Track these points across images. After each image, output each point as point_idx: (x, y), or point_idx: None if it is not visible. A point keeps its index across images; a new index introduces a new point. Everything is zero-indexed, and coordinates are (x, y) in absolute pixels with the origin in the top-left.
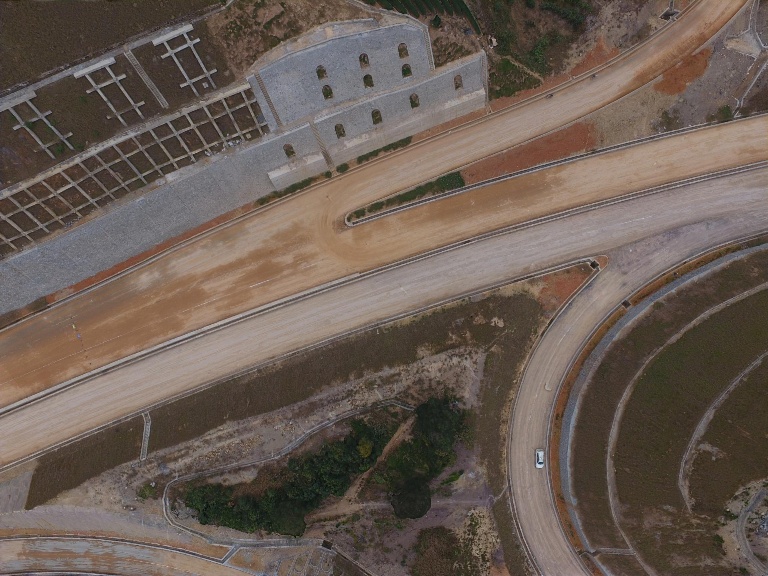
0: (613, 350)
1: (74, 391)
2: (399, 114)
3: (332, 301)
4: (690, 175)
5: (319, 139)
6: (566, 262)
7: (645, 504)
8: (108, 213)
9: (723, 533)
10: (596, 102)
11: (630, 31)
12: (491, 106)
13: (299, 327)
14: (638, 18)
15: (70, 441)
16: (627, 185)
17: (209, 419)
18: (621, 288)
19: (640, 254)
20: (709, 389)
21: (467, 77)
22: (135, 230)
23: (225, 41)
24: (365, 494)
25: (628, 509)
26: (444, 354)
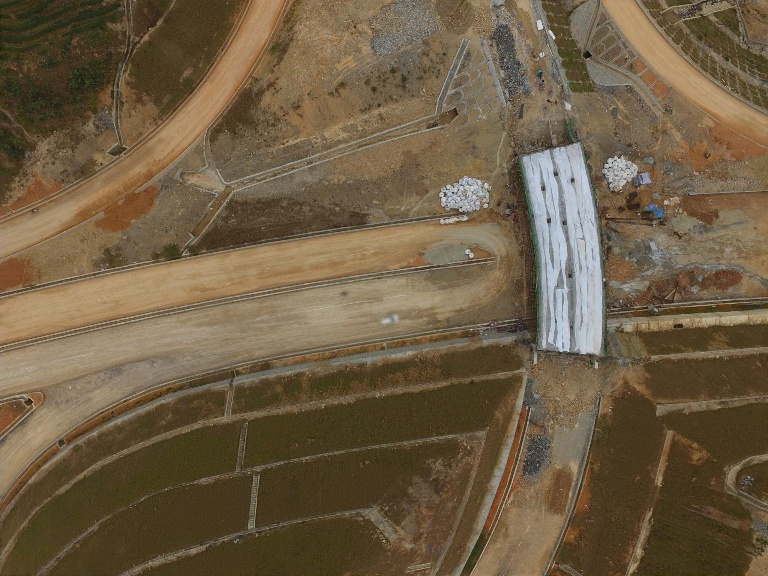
0: (26, 493)
1: None
2: None
3: None
4: (136, 312)
5: None
6: None
7: None
8: None
9: None
10: (35, 237)
11: (69, 167)
12: None
13: None
14: (76, 155)
15: None
16: (69, 321)
17: None
18: (58, 425)
19: (80, 391)
20: (45, 554)
21: None
22: None
23: None
24: None
25: None
26: None
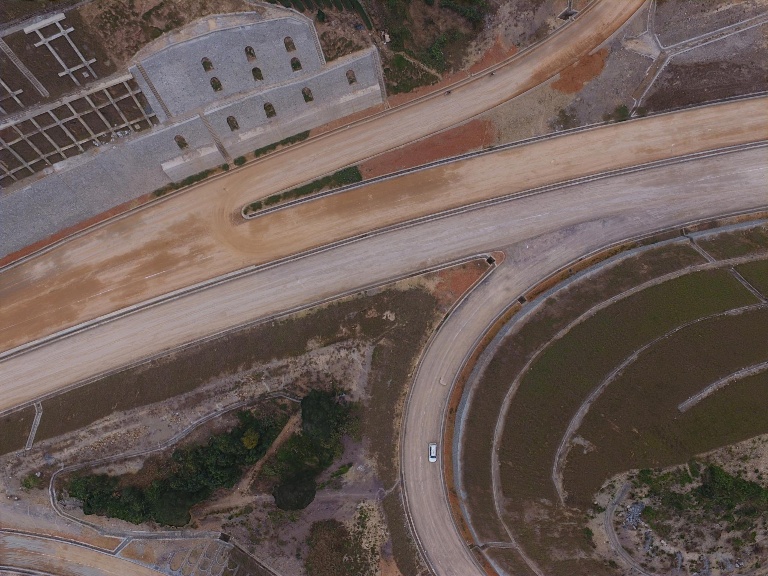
0: (505, 345)
1: None
2: (293, 108)
3: (228, 293)
4: (587, 173)
5: (212, 131)
6: (463, 257)
7: (525, 497)
8: None
9: (592, 526)
10: (494, 99)
11: (528, 30)
12: (389, 102)
13: (195, 319)
14: (535, 17)
15: None
16: (524, 182)
17: (97, 409)
18: (517, 284)
19: (537, 250)
20: (586, 383)
21: (360, 72)
22: (26, 219)
23: (101, 31)
24: (257, 486)
25: (511, 502)
26: (332, 347)
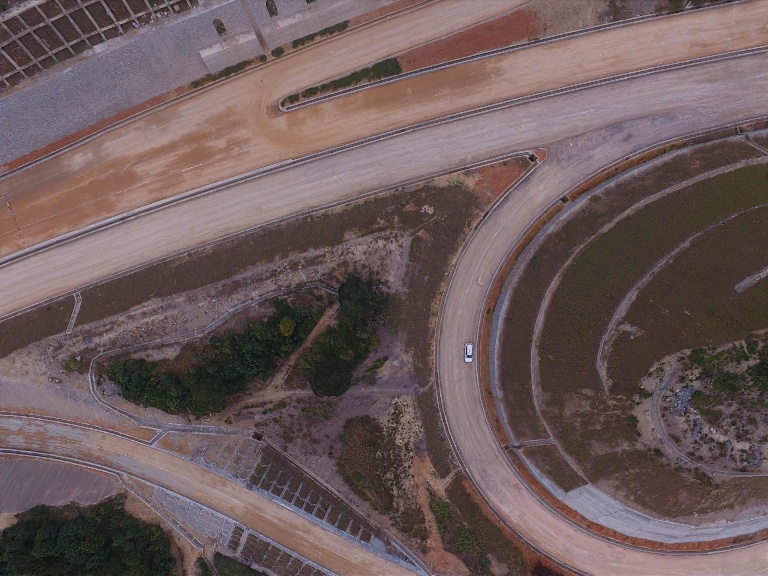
0: (546, 243)
1: (8, 270)
2: None
3: (264, 188)
4: (637, 68)
5: (251, 16)
6: (504, 154)
7: (566, 390)
8: (36, 83)
9: (638, 413)
10: None
11: None
12: None
13: (231, 213)
14: None
15: (3, 318)
16: (570, 77)
17: (135, 297)
18: (560, 183)
19: (581, 149)
20: (634, 271)
21: None
22: (66, 106)
23: None
24: (292, 381)
25: (550, 397)
26: (370, 236)
